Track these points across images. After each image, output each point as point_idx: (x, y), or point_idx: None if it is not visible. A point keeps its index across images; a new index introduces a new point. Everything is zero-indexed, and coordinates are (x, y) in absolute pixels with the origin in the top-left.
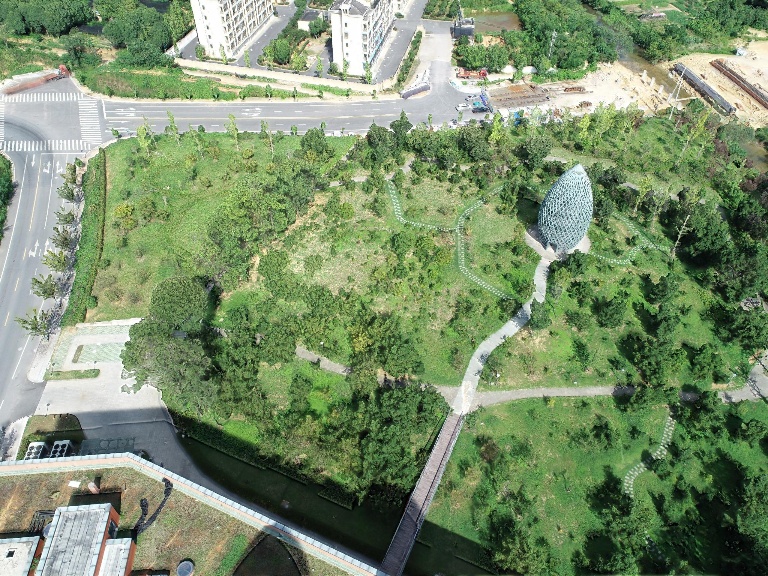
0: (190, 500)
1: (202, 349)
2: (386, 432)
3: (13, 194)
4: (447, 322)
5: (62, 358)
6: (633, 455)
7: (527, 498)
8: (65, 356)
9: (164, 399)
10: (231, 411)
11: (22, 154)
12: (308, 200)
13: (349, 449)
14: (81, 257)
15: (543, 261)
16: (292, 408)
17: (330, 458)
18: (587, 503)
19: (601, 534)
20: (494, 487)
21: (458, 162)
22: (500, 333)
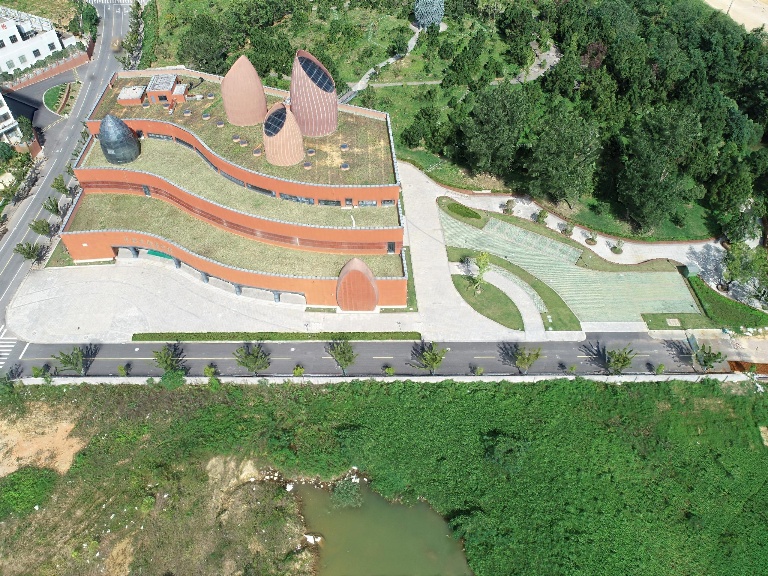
0: (212, 83)
1: None
2: None
3: (99, 21)
4: (356, 60)
5: None
6: (443, 103)
7: None
8: None
9: None
10: None
11: (101, 5)
12: (281, 11)
13: None
14: (146, 42)
15: (417, 35)
16: None
17: None
18: (414, 118)
19: None
20: None
21: (380, 0)
22: (384, 63)
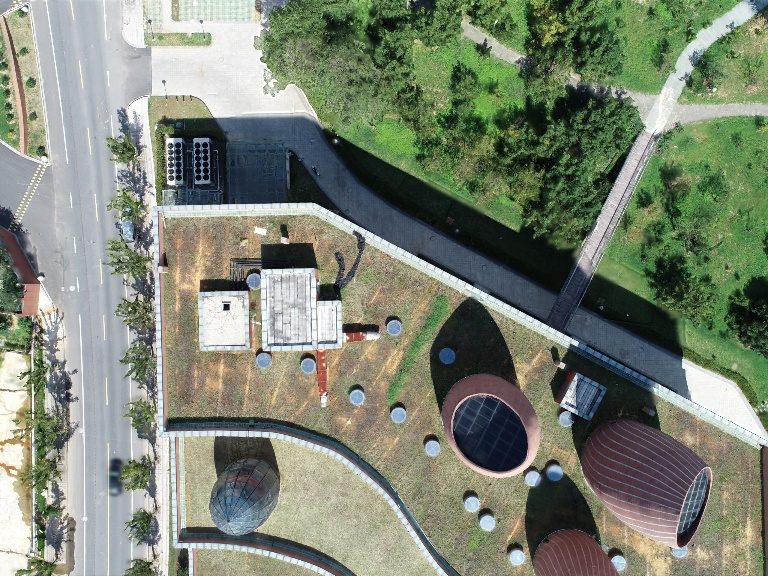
0: (386, 257)
1: (370, 60)
2: (577, 167)
3: None
4: None
5: (157, 12)
6: None
7: (703, 235)
8: (160, 9)
9: (317, 106)
10: (387, 113)
11: None
12: None
13: (531, 181)
14: None
15: None
16: (457, 113)
17: (504, 183)
18: (764, 244)
19: (767, 275)
20: (672, 221)
21: None
22: (728, 18)
